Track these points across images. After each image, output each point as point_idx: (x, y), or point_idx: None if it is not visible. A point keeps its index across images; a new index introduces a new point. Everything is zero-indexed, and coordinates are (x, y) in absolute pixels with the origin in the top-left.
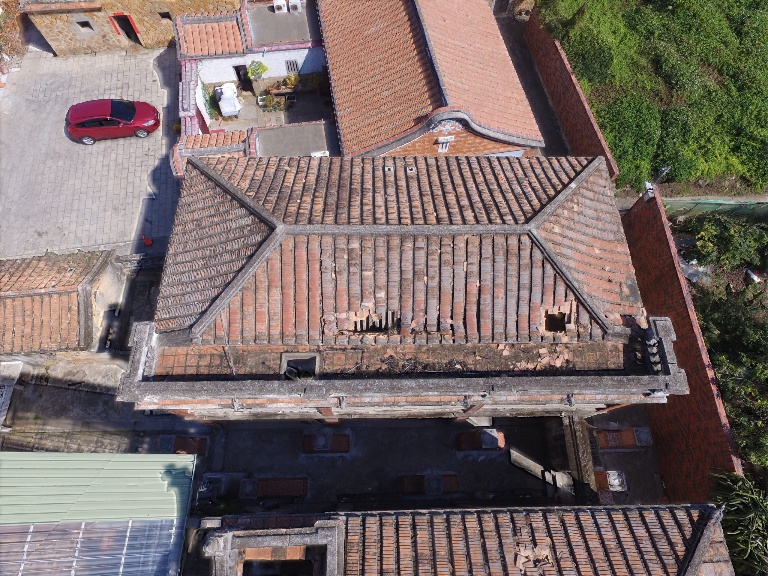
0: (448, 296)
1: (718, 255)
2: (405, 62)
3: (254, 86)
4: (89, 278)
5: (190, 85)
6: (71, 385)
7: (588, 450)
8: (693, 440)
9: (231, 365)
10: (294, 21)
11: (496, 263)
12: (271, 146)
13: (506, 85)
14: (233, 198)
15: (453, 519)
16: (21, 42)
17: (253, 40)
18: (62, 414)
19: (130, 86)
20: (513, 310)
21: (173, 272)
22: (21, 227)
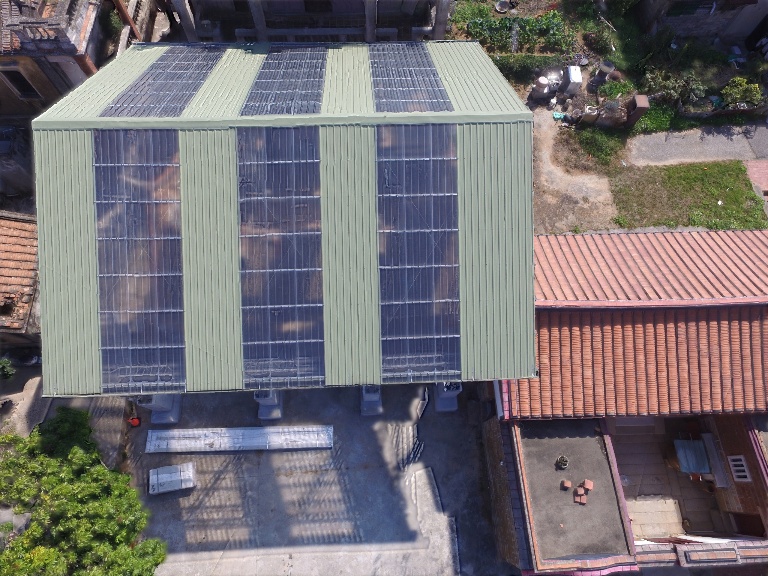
0: None
1: None
2: None
3: None
4: None
5: None
6: None
7: None
8: None
9: None
10: None
11: None
12: None
13: None
14: None
15: None
16: None
17: None
18: None
19: None
20: None
21: None
22: None
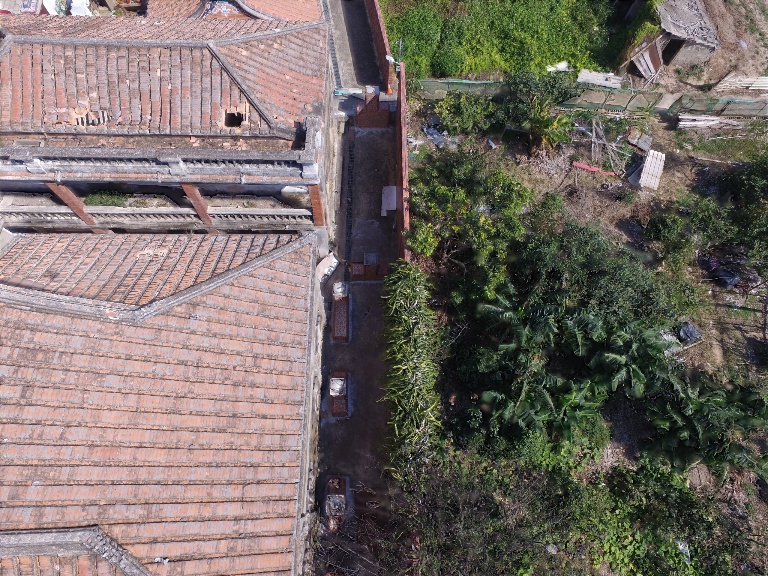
0: (146, 96)
1: (451, 120)
2: None
3: (107, 0)
4: None
5: None
6: None
7: None
8: (401, 255)
9: None
10: None
11: (183, 70)
12: None
13: None
14: None
15: (106, 236)
16: None
17: None
18: None
19: (1, 1)
20: (197, 108)
21: None
22: None
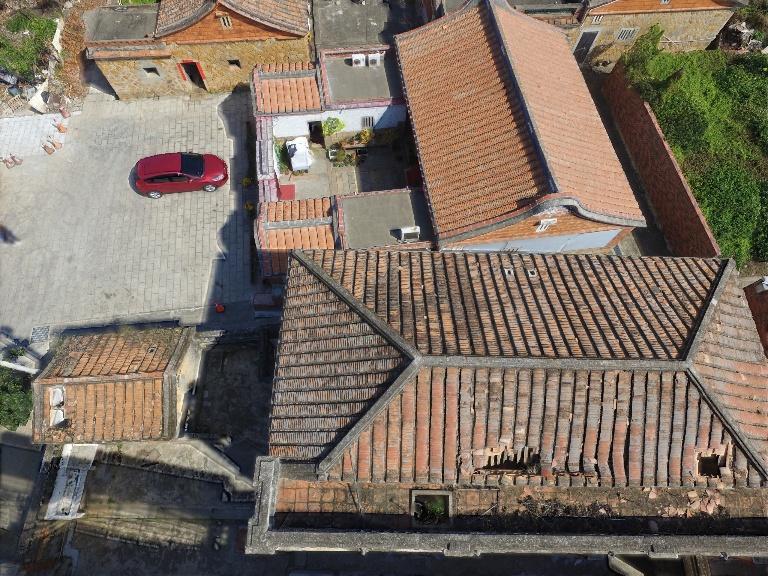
0: (594, 435)
1: None
2: (503, 135)
3: (326, 140)
4: (173, 363)
5: (267, 145)
6: (145, 466)
7: (709, 574)
8: None
9: (357, 502)
10: (373, 76)
11: (649, 402)
12: (356, 217)
13: (603, 157)
14: (352, 310)
15: None
16: (82, 83)
17: (331, 96)
18: (136, 498)
19: (195, 134)
20: (665, 452)
21: (287, 388)
22: (88, 288)
